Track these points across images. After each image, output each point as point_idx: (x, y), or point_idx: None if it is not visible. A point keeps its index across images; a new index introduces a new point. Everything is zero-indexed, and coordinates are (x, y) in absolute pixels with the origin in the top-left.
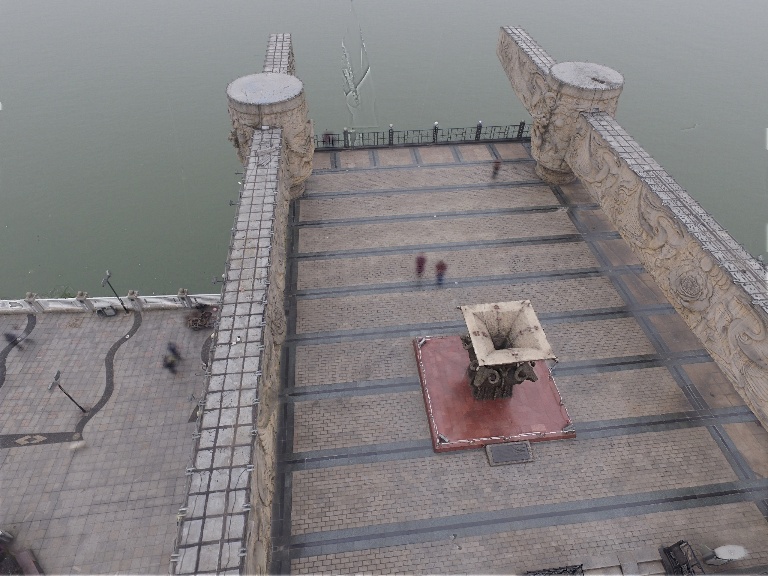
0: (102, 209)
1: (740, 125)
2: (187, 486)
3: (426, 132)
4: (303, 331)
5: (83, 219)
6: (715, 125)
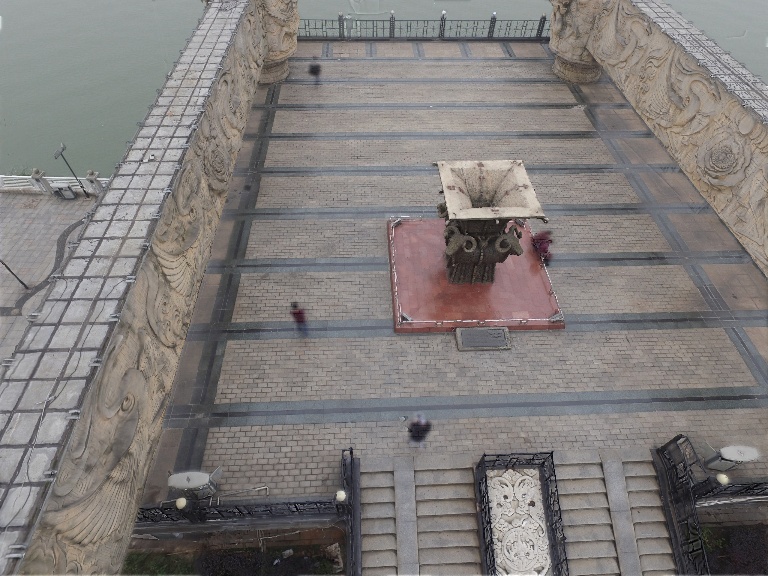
0: (75, 97)
1: None
2: (48, 293)
3: (432, 23)
4: (263, 206)
5: (53, 105)
6: None
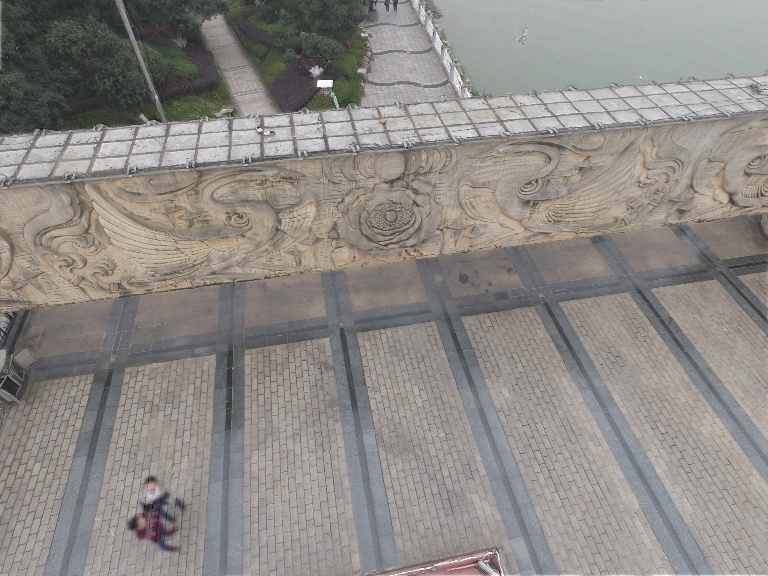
0: None
1: None
2: None
3: None
4: (469, 325)
5: None
6: None
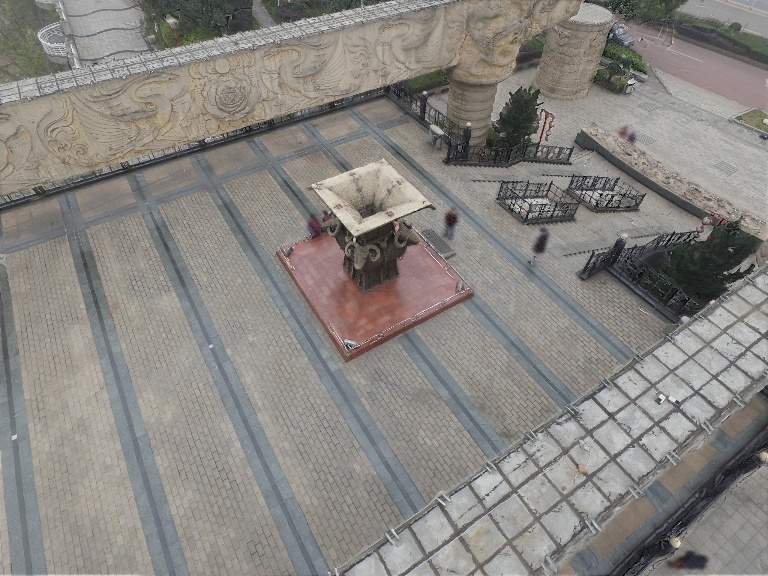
0: None
1: None
2: None
3: None
4: None
5: None
6: None
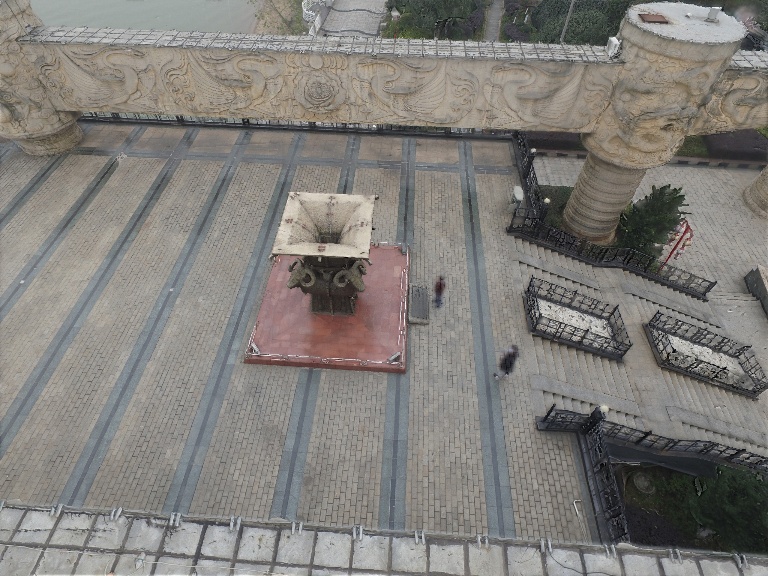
0: None
1: (110, 10)
2: None
3: None
4: None
5: None
6: (96, 19)
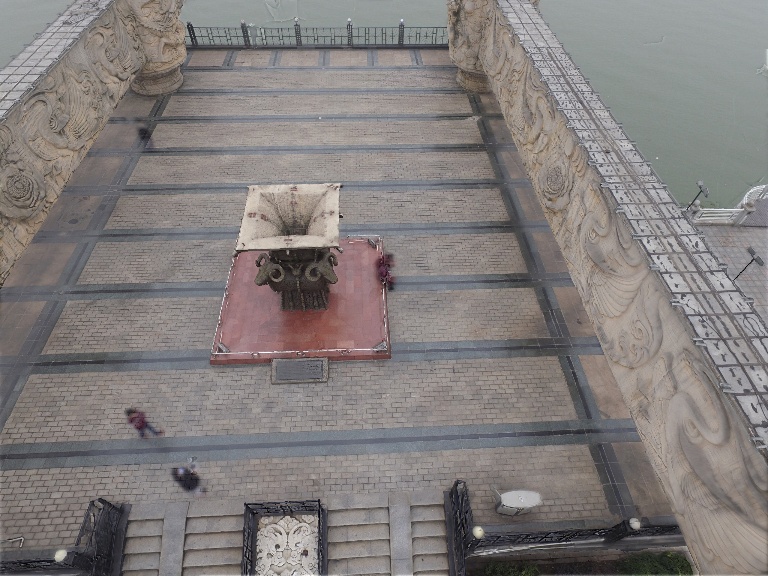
0: None
1: (717, 41)
2: None
3: (339, 31)
4: (113, 227)
5: None
6: (687, 40)
